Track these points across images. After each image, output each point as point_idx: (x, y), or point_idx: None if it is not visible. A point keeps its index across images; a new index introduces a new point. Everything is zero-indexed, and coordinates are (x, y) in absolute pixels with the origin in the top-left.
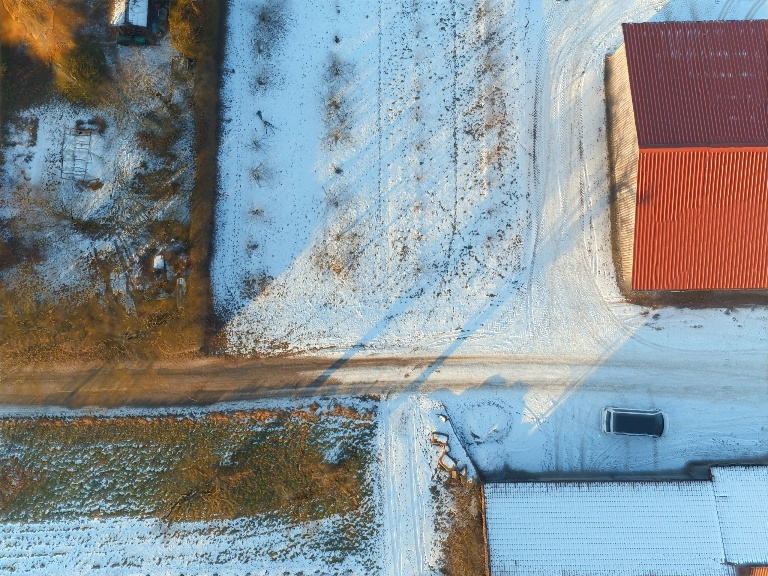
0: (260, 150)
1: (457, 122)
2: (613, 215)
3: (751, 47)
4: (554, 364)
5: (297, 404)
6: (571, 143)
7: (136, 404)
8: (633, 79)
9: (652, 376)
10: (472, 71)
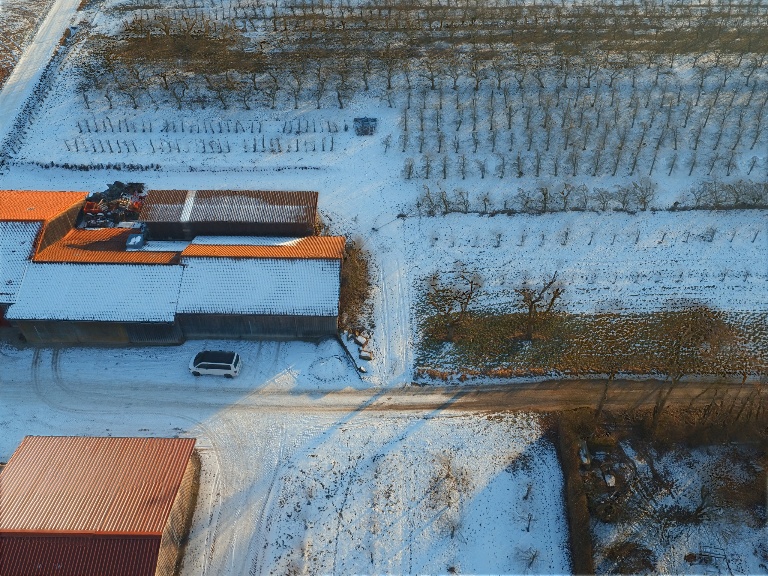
0: None
1: None
2: (188, 527)
3: None
4: (269, 406)
5: (477, 381)
6: None
7: (604, 382)
8: None
9: (192, 397)
10: None
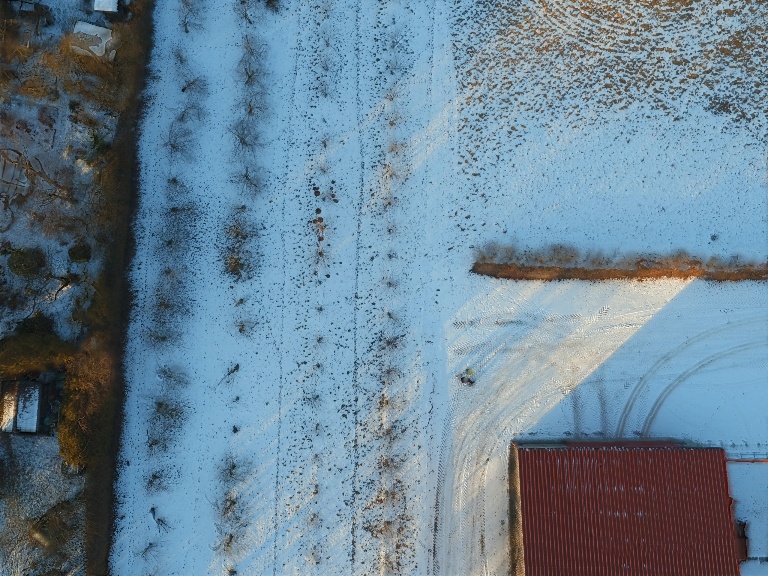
0: (150, 557)
1: (355, 517)
2: None
3: (648, 481)
4: None
5: None
6: (472, 537)
7: None
8: (525, 517)
9: None
10: (373, 462)
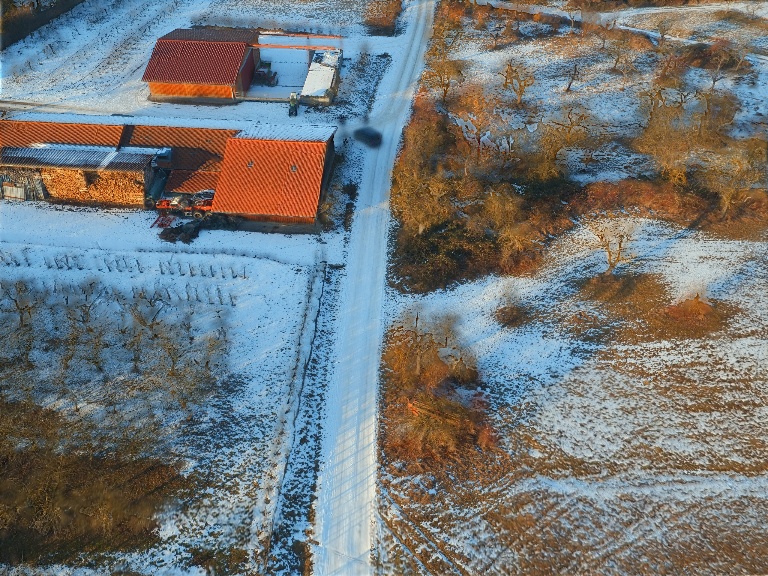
0: (9, 53)
1: None
2: None
3: None
4: None
5: None
6: None
7: None
8: None
9: None
10: None
